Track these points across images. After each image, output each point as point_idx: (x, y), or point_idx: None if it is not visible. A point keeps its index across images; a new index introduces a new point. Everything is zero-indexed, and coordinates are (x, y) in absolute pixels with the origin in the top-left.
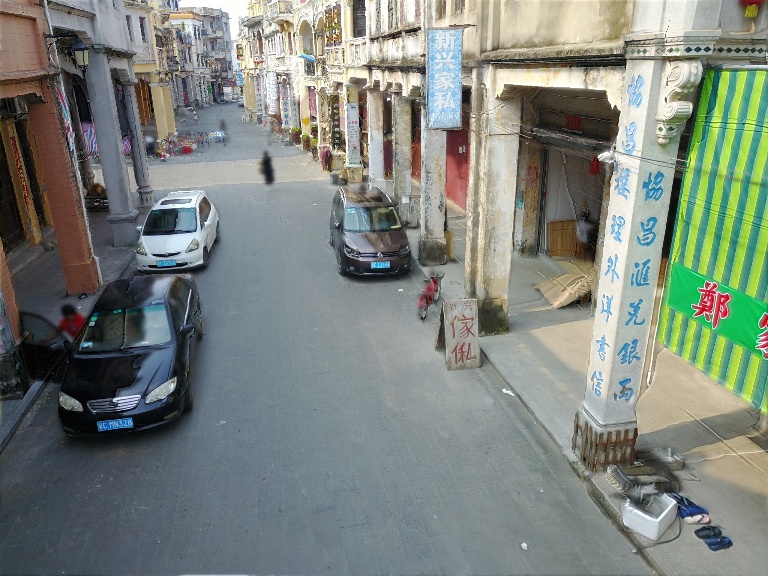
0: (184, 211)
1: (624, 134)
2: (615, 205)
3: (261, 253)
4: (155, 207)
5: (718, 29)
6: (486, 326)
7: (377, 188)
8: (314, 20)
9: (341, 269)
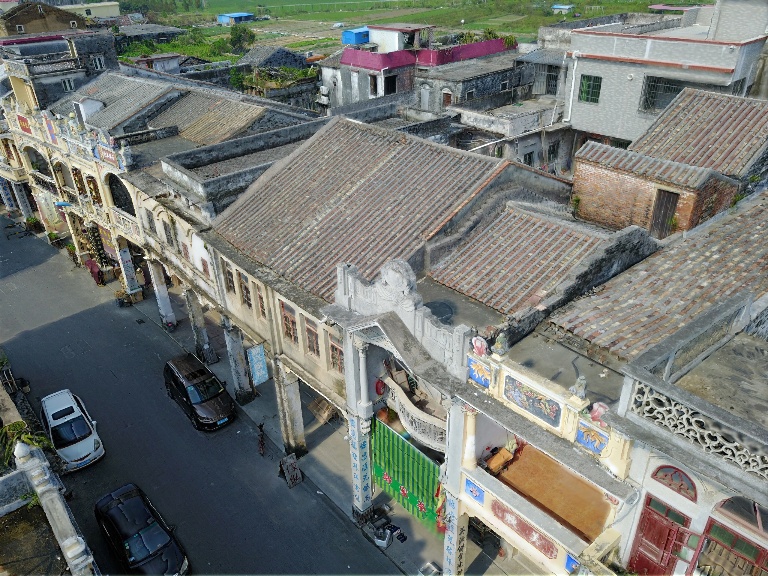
0: (76, 421)
1: (351, 432)
2: (352, 449)
3: (130, 423)
4: (52, 424)
5: None
6: (298, 455)
7: (193, 356)
8: (51, 160)
9: (198, 428)
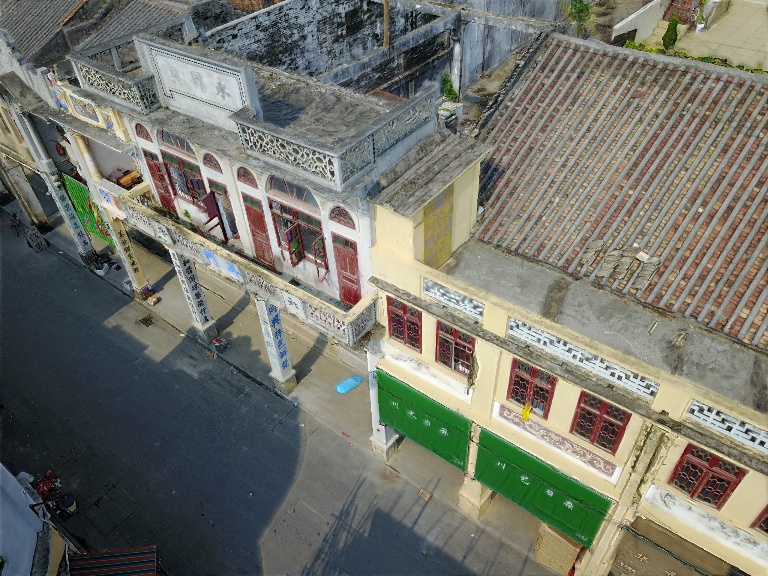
0: None
1: (49, 188)
2: (57, 203)
3: None
4: None
5: (56, 168)
6: (44, 231)
7: None
8: None
9: None
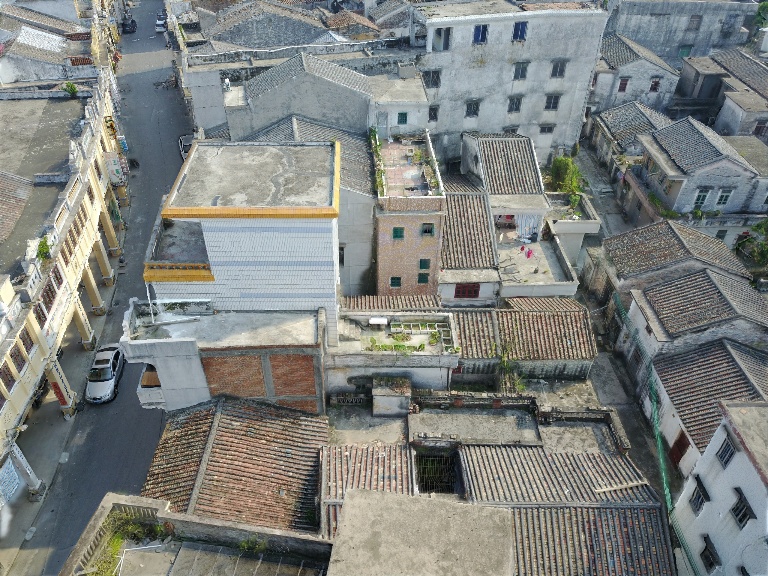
0: None
1: None
2: None
3: None
4: None
5: None
6: None
7: None
8: None
9: None
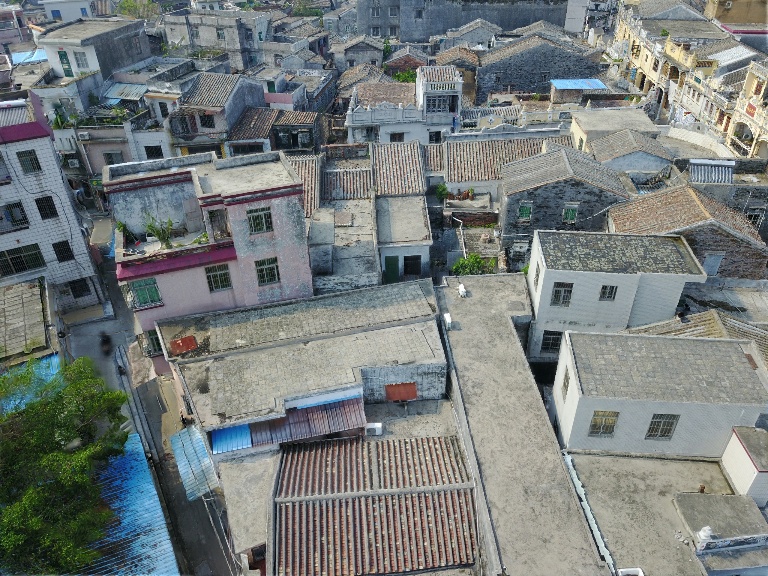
0: None
1: None
2: None
3: None
4: None
5: None
6: None
7: None
8: (759, 138)
9: None
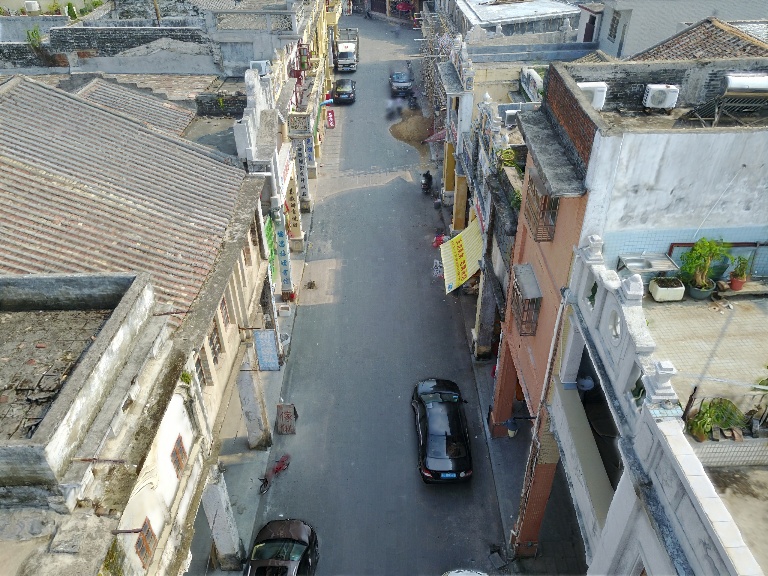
0: None
1: None
2: None
3: None
4: None
5: None
6: None
7: None
8: None
9: None
